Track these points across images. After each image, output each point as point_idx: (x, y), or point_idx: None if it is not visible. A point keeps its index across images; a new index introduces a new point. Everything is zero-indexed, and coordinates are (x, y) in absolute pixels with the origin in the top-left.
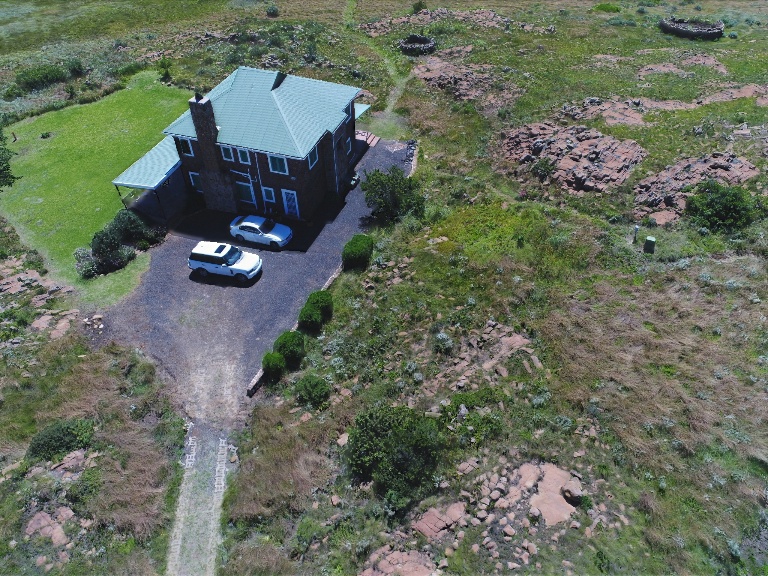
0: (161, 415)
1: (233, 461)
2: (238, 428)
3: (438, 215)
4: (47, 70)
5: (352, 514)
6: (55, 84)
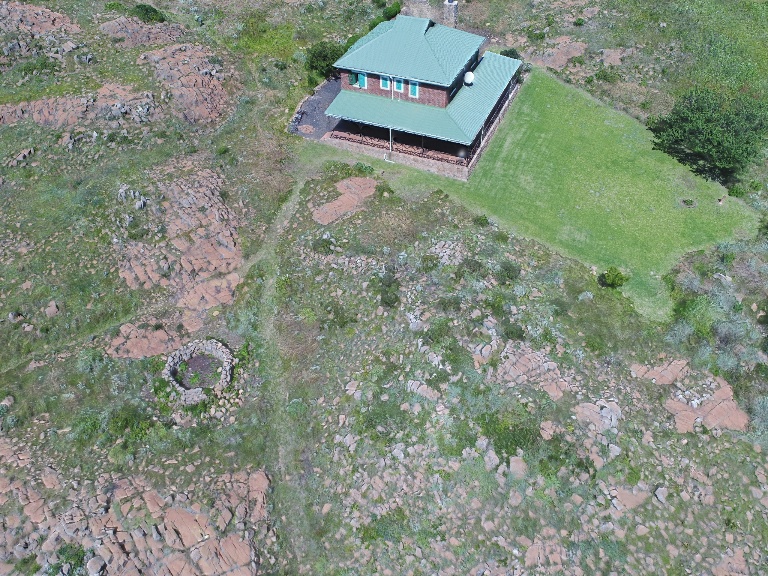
0: None
1: None
2: (408, 1)
3: None
4: None
5: None
6: None
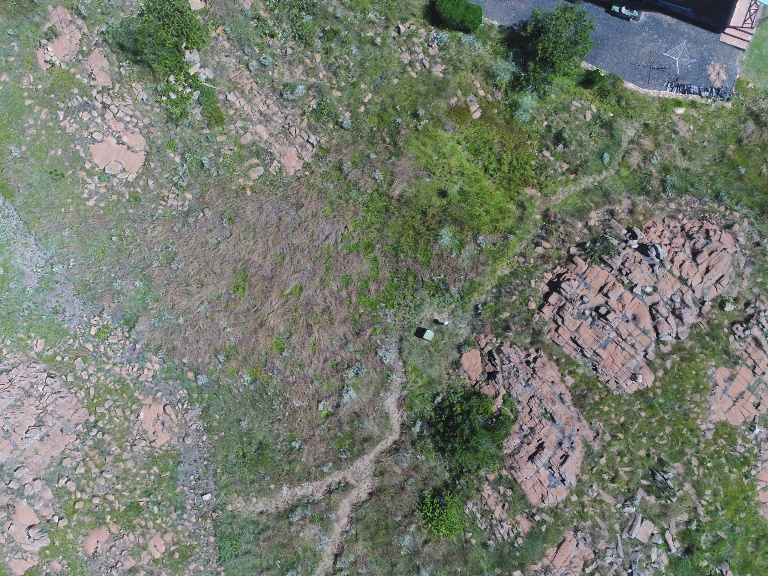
0: None
1: None
2: None
3: (518, 108)
4: None
5: (113, 4)
6: None
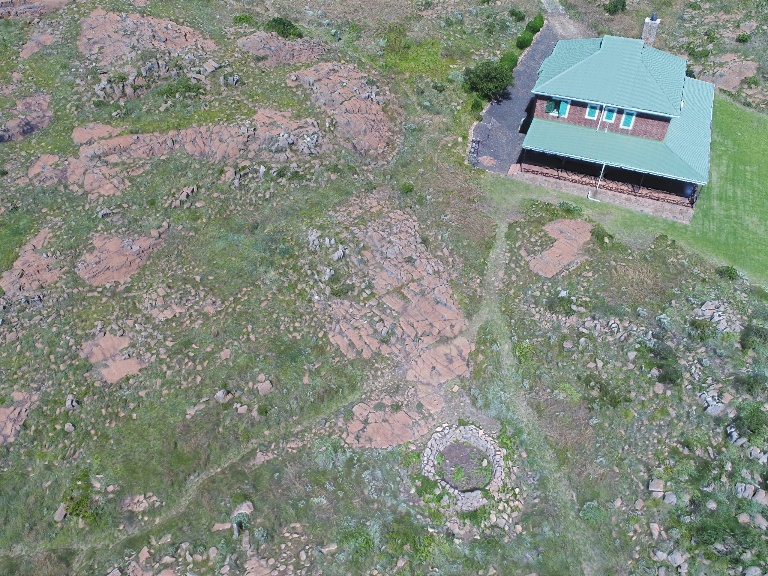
0: None
1: None
2: None
3: None
4: None
5: None
6: None
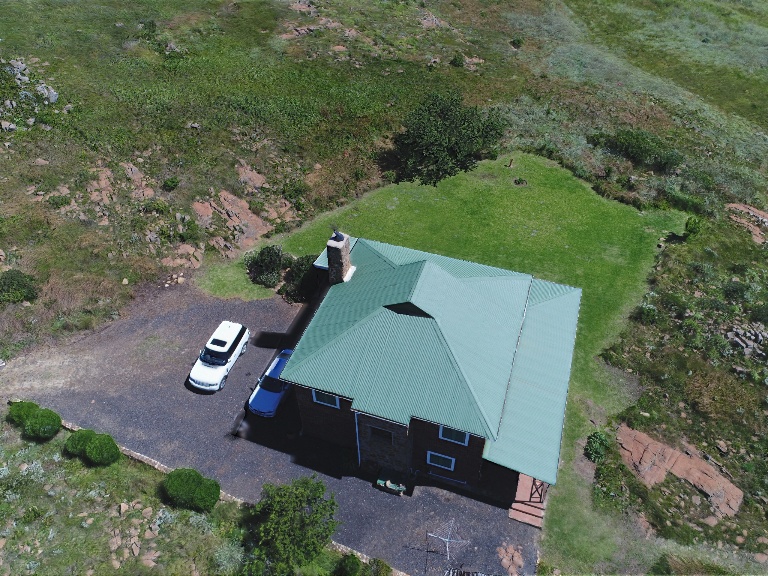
0: None
1: None
2: None
3: None
4: (636, 143)
5: None
6: (624, 158)
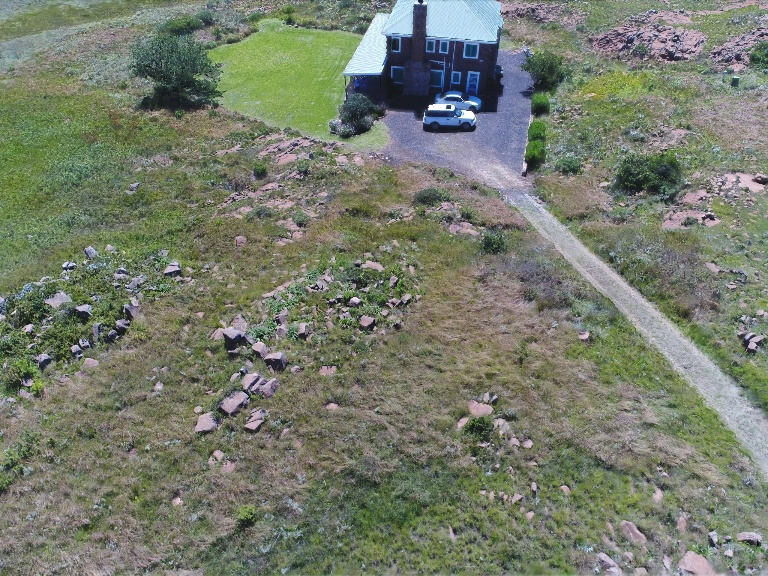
0: (476, 188)
1: (540, 202)
2: (531, 189)
3: (582, 82)
4: (189, 19)
5: None
6: (197, 31)
